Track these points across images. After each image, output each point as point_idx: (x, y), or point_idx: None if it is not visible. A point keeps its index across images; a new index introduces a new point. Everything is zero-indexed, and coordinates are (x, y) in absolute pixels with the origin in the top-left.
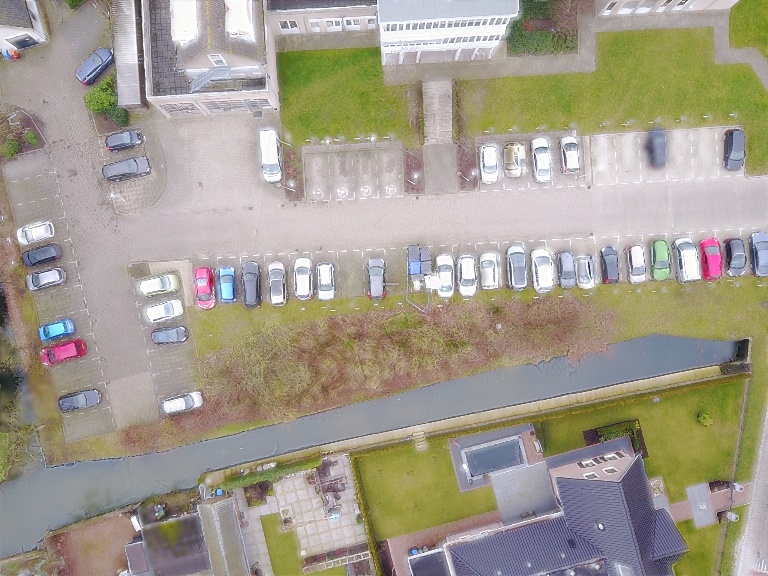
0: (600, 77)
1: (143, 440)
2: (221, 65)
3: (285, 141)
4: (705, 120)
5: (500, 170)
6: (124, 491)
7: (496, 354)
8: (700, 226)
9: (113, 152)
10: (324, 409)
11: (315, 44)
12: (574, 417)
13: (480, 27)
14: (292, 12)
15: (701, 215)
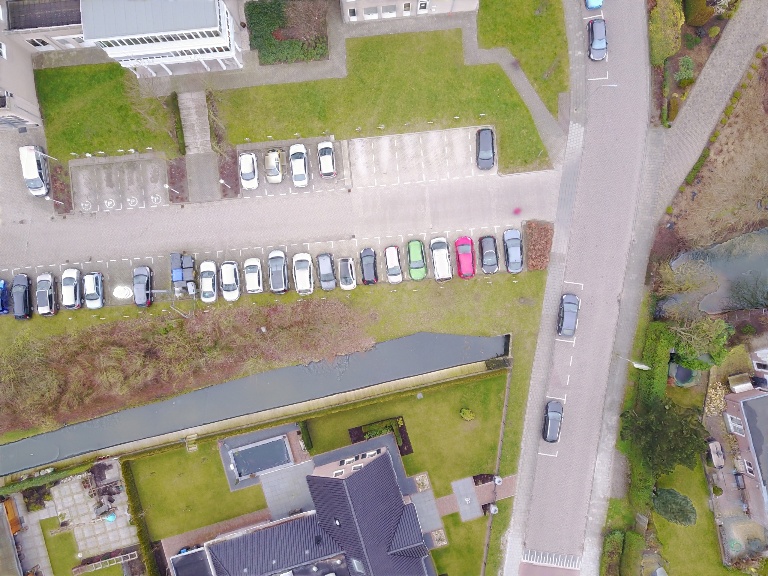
0: (351, 82)
1: None
2: None
3: (51, 155)
4: (457, 121)
5: (262, 176)
6: None
7: (265, 356)
8: (457, 225)
9: None
10: (100, 415)
11: (72, 60)
12: (339, 416)
13: (196, 40)
14: (29, 31)
15: (457, 214)
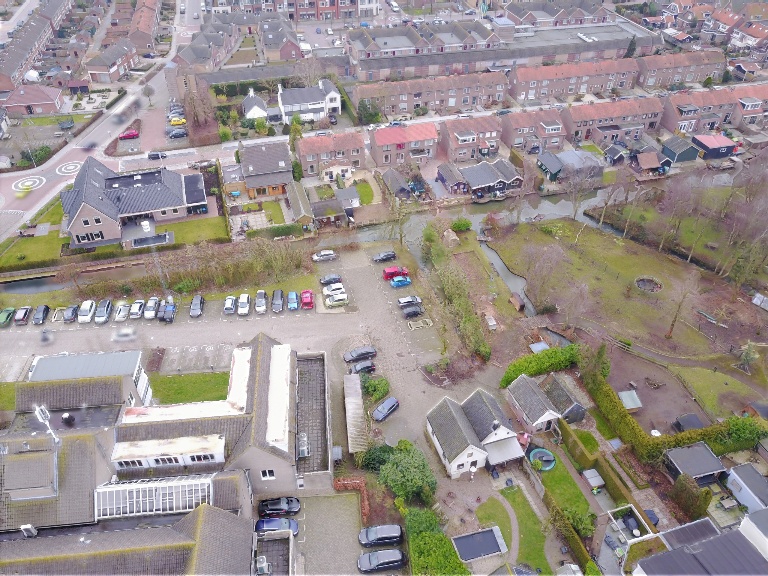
0: None
1: None
2: None
3: None
4: None
5: None
6: None
7: None
8: None
9: None
10: None
11: None
12: None
13: None
14: None
15: None
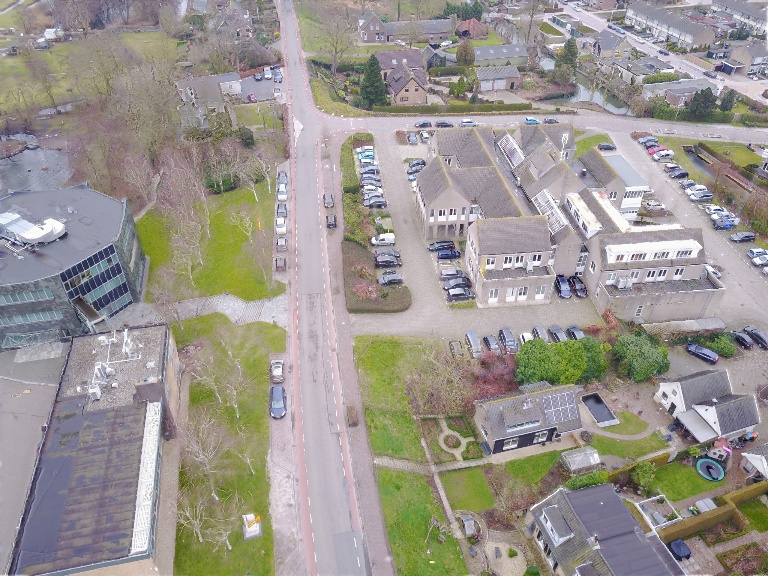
0: None
1: None
2: None
3: None
4: None
5: None
6: None
7: None
8: (644, 156)
9: None
10: None
11: None
12: None
13: None
14: None
15: (639, 155)
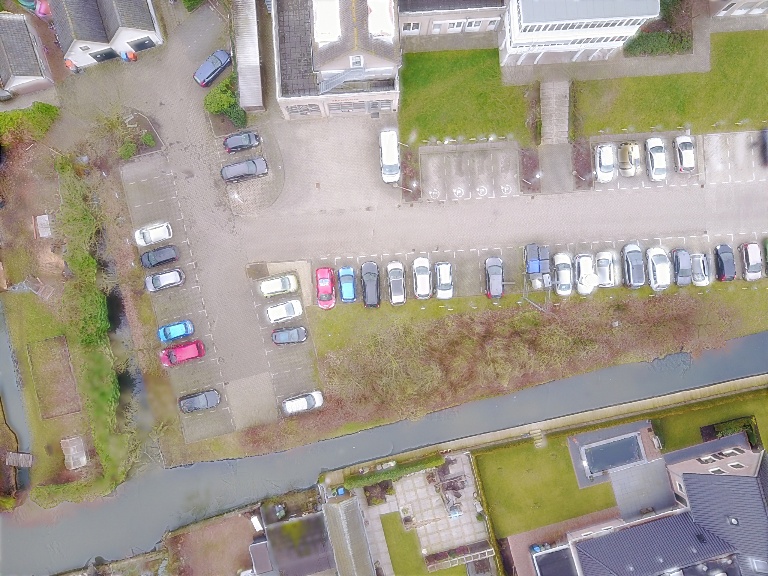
0: (715, 77)
1: (262, 440)
2: (357, 66)
3: (402, 142)
4: None
5: (614, 169)
6: (223, 492)
7: (612, 352)
8: None
9: (230, 154)
10: (441, 408)
11: (434, 46)
12: (691, 414)
13: (614, 28)
14: (421, 14)
15: None
